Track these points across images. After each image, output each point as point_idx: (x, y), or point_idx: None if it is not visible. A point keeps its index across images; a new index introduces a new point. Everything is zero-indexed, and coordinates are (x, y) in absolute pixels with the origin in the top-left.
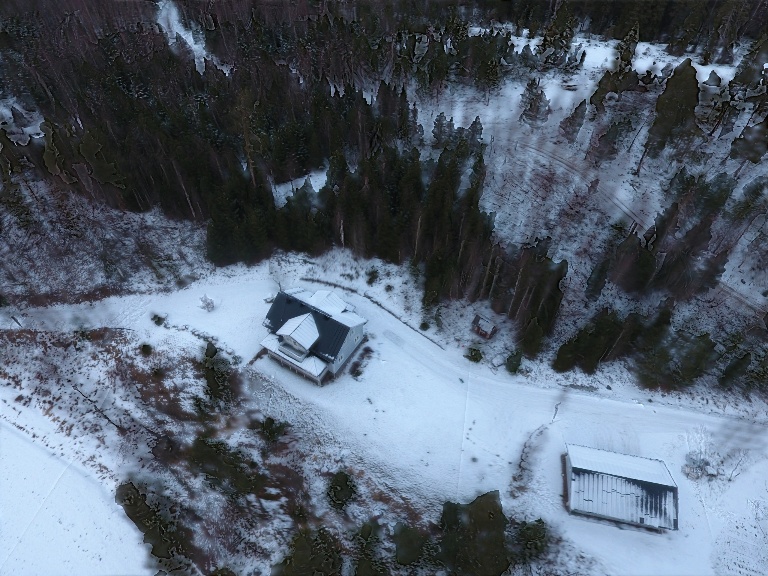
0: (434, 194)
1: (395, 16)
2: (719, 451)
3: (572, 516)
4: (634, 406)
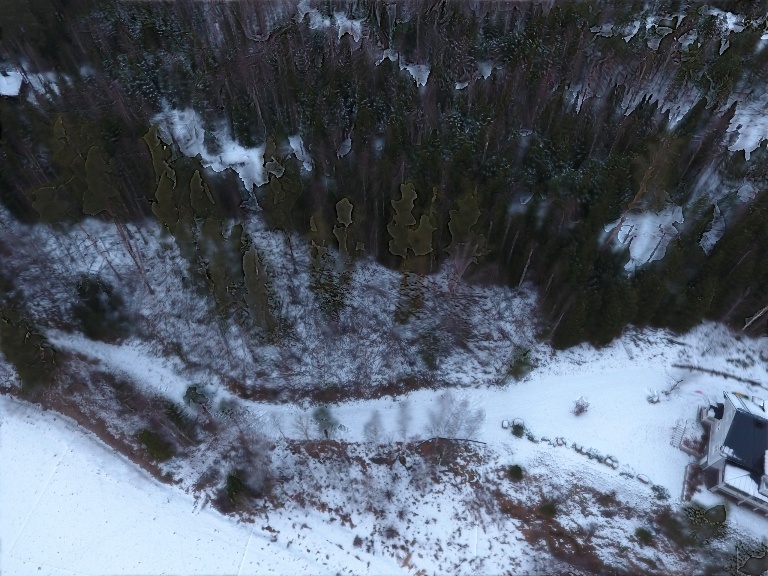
0: None
1: (598, 2)
2: None
3: None
4: None
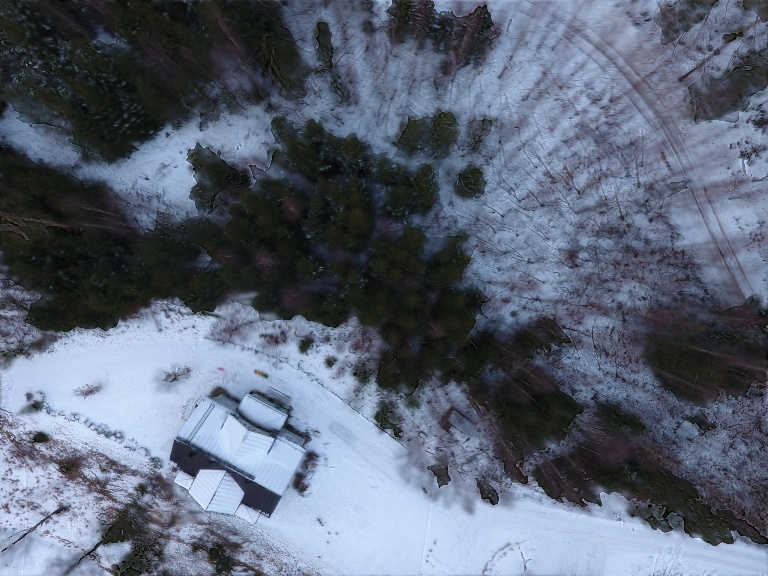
0: (387, 272)
1: None
2: (684, 572)
3: None
4: (613, 524)
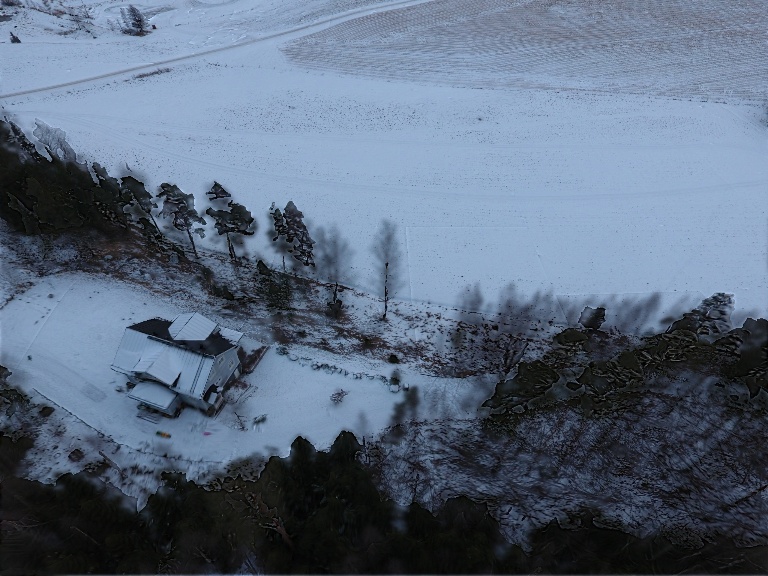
0: None
1: None
2: None
3: None
4: None
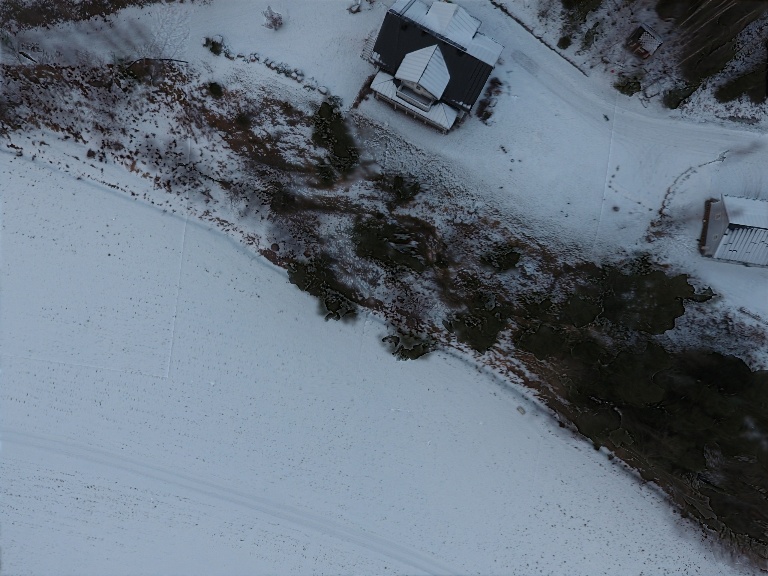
0: None
1: None
2: None
3: (705, 258)
4: None
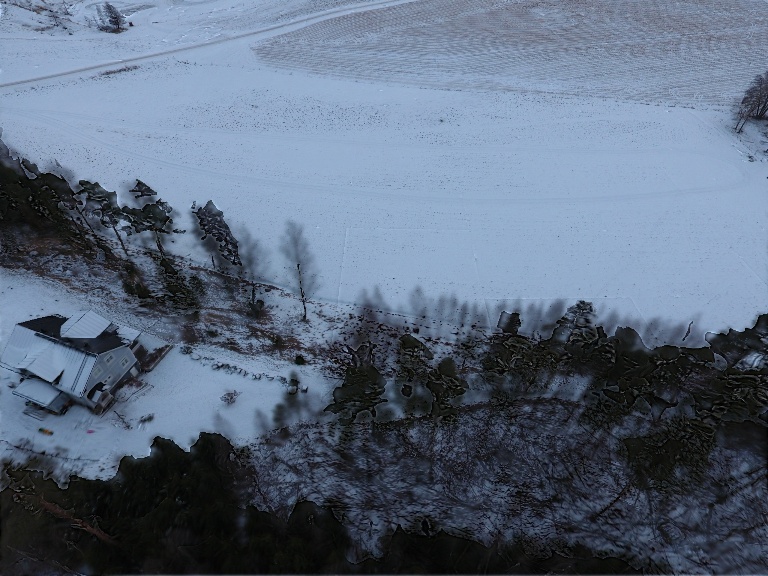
0: None
1: None
2: None
3: None
4: None
